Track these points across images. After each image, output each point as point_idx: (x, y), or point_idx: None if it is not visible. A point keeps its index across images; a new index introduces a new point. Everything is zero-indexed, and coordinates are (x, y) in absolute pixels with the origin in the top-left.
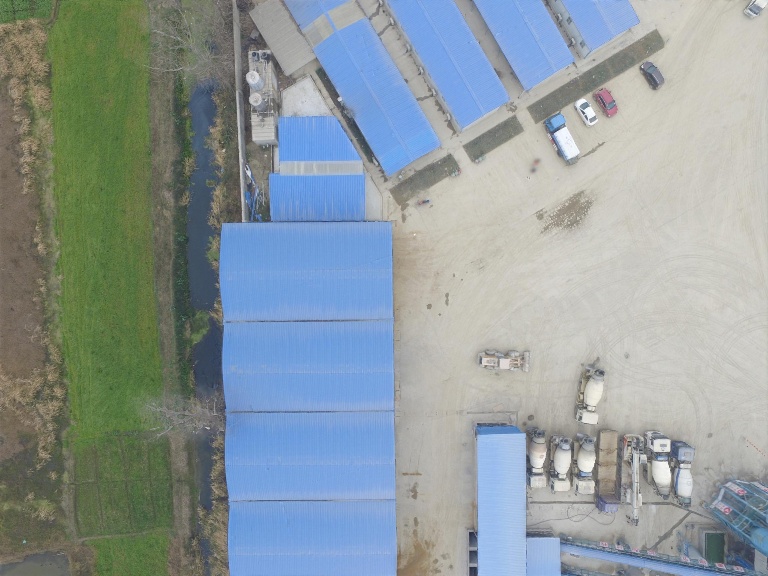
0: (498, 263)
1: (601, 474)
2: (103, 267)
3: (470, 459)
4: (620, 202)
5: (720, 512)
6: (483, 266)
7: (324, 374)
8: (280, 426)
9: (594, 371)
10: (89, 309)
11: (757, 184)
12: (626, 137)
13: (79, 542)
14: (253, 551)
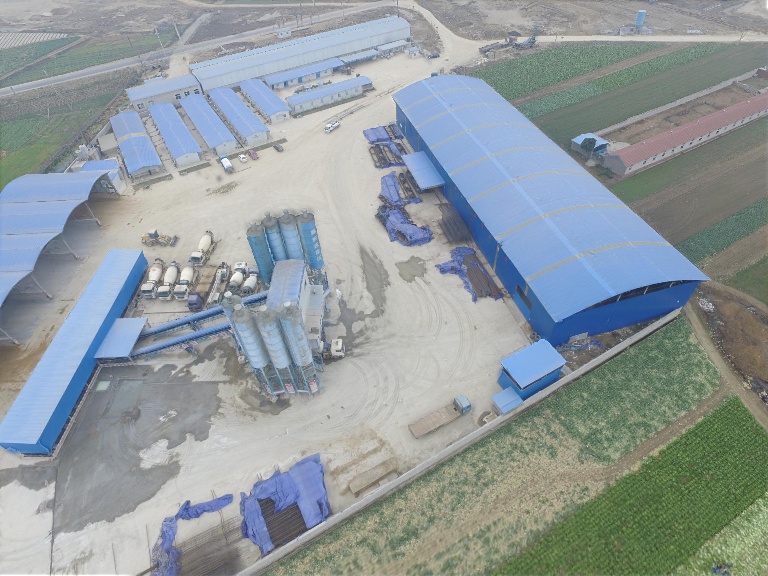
0: (177, 207)
1: (198, 289)
2: None
3: None
4: (253, 184)
5: None
6: (168, 208)
7: (31, 215)
8: None
9: None
10: None
11: (327, 175)
12: (262, 165)
13: None
14: None
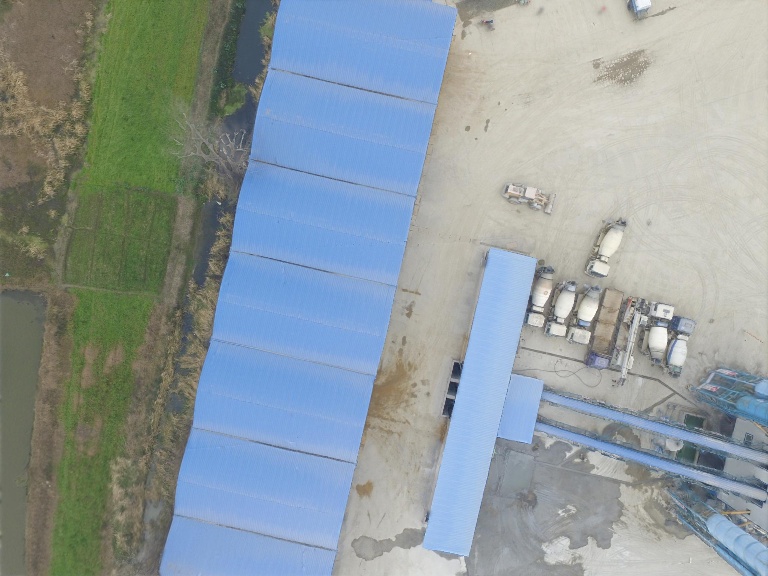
0: (545, 101)
1: (598, 331)
2: (154, 16)
3: (472, 290)
4: (677, 69)
5: (706, 390)
6: (530, 101)
7: (357, 139)
8: (300, 184)
9: (616, 221)
10: (130, 54)
11: None
12: (697, 7)
13: (62, 287)
14: (243, 302)
